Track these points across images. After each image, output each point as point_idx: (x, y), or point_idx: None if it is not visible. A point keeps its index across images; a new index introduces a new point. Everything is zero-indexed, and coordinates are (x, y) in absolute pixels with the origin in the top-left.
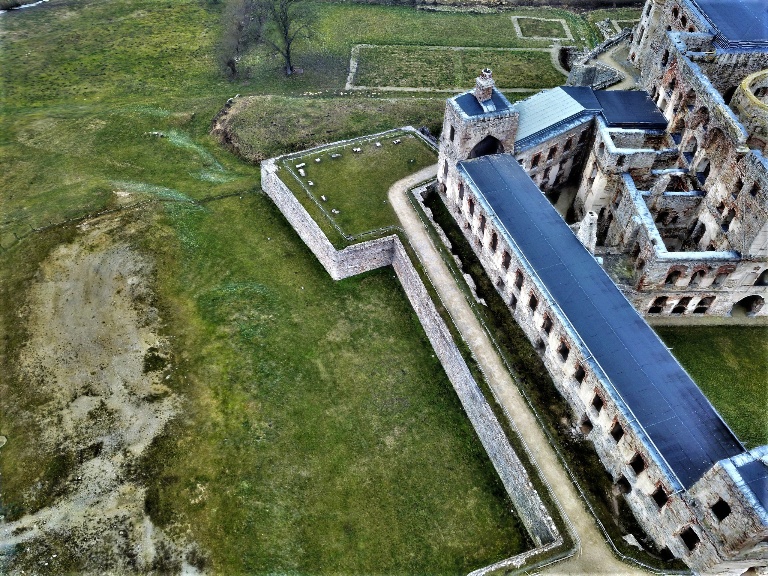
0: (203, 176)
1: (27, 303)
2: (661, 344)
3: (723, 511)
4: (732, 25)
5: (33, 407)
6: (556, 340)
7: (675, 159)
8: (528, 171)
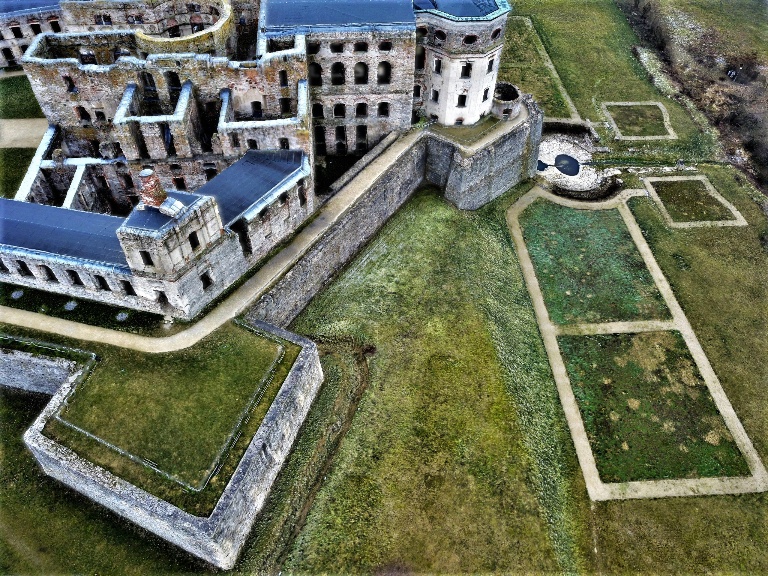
0: None
1: None
2: (42, 6)
3: None
4: None
5: None
6: None
7: None
8: None
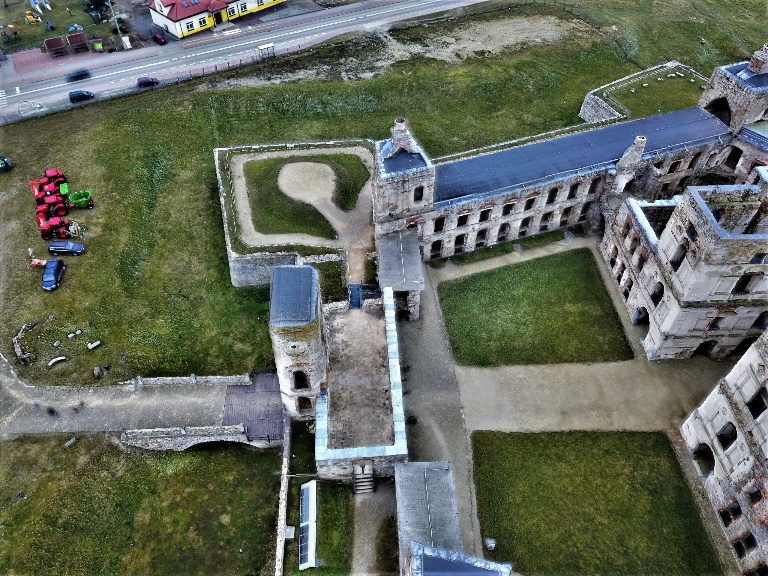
0: (664, 62)
1: (509, 17)
2: (526, 181)
3: None
4: None
5: (446, 29)
6: None
7: None
8: (745, 173)
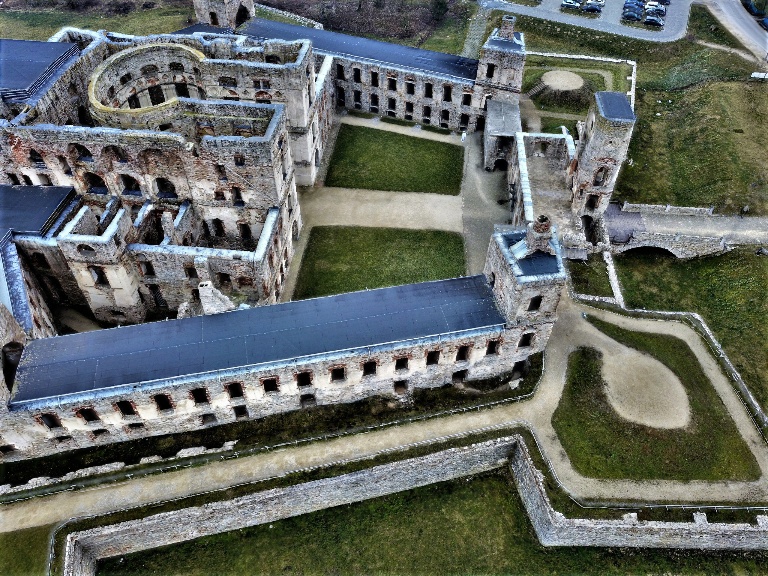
0: None
1: None
2: (364, 292)
3: (536, 303)
4: None
5: None
6: (324, 377)
7: (120, 205)
8: None
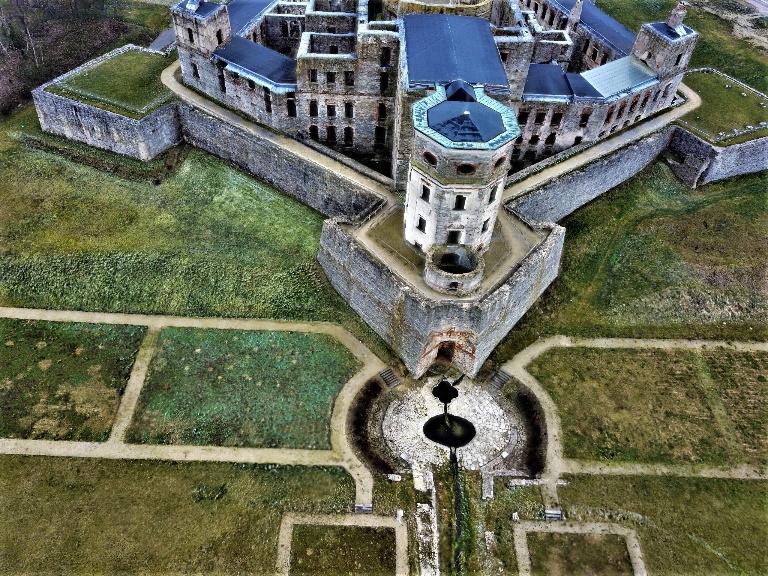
0: None
1: None
2: None
3: None
4: (478, 30)
5: None
6: None
7: None
8: None
